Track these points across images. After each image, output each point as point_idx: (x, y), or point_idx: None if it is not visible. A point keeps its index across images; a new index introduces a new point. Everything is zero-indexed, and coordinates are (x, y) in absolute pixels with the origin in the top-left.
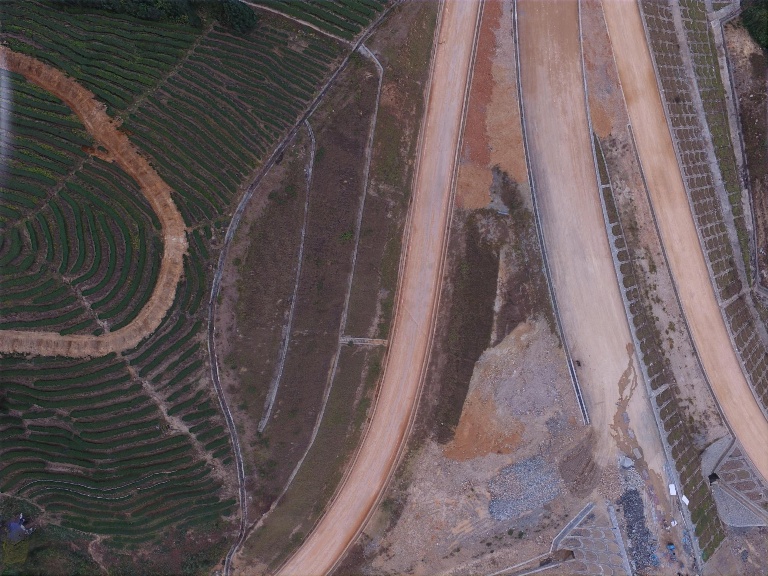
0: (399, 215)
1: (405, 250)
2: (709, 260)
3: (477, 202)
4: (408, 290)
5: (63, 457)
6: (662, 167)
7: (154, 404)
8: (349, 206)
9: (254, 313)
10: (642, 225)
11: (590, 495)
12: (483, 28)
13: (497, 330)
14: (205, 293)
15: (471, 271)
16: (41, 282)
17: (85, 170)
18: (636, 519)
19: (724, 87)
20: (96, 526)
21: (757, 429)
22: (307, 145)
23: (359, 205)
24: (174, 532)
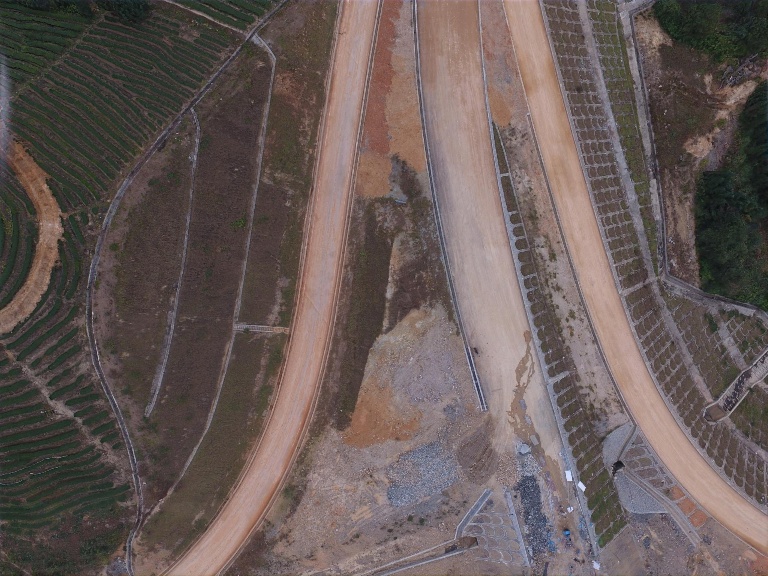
0: (300, 204)
1: (306, 239)
2: (609, 248)
3: (376, 191)
4: (310, 278)
5: None
6: (562, 156)
7: (36, 388)
8: (241, 194)
9: (135, 298)
10: (542, 214)
11: (488, 481)
12: (383, 18)
13: (389, 317)
14: (82, 278)
15: (368, 259)
16: None
17: None
18: (533, 505)
19: (633, 78)
20: None
21: (658, 416)
22: (192, 133)
23: (252, 193)
24: (71, 517)
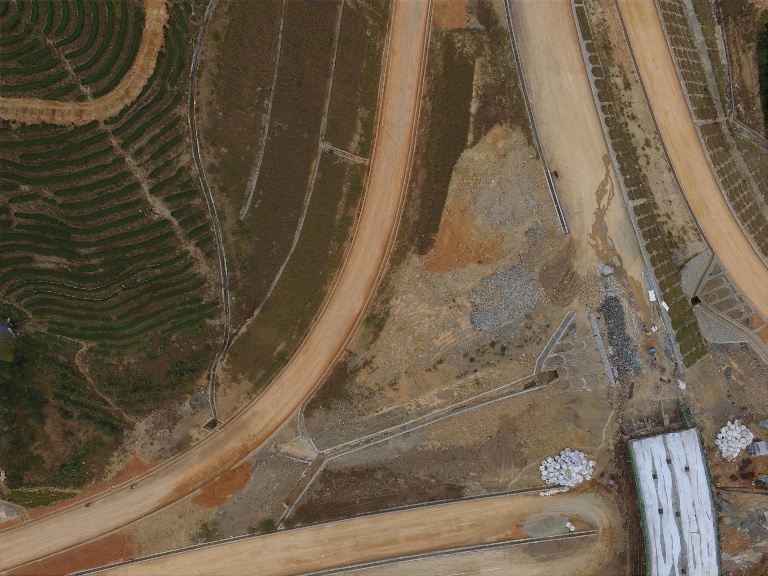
0: (378, 37)
1: (384, 71)
2: (682, 78)
3: (454, 22)
4: (388, 111)
5: (49, 249)
6: None
7: (137, 182)
8: (327, 12)
9: (234, 94)
10: (616, 44)
11: (571, 304)
12: None
13: (474, 131)
14: (185, 66)
15: (448, 84)
16: (26, 44)
17: None
18: (617, 325)
19: None
20: (82, 332)
21: (736, 245)
22: None
23: (337, 14)
24: (159, 337)
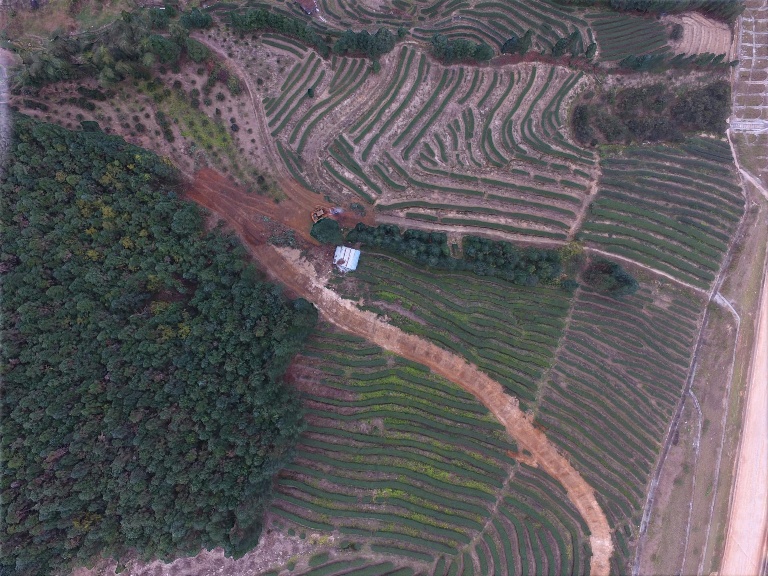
0: (731, 447)
1: (735, 482)
2: None
3: None
4: (737, 521)
5: None
6: None
7: None
8: (711, 460)
9: None
10: None
11: None
12: None
13: None
14: None
15: None
16: None
17: (515, 478)
18: None
19: None
20: None
21: None
22: (695, 418)
23: (717, 456)
24: None
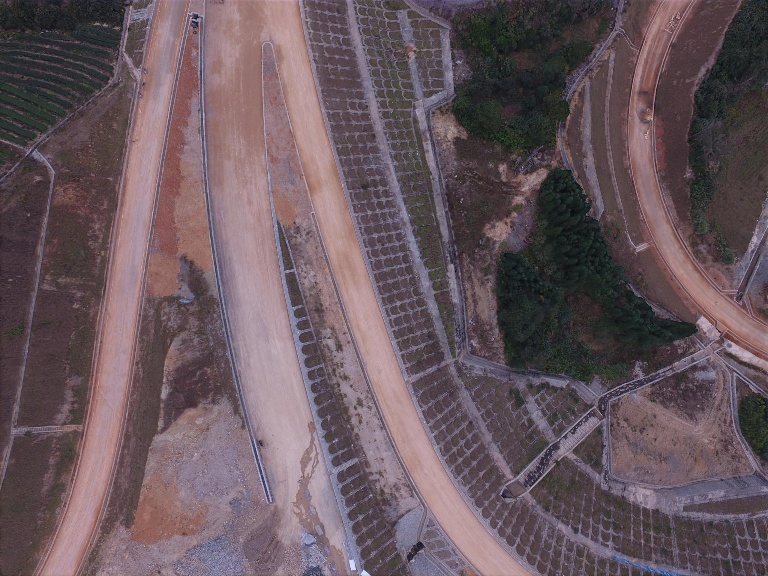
0: (92, 304)
1: (99, 337)
2: (394, 337)
3: (165, 290)
4: (103, 375)
5: None
6: (346, 251)
7: None
8: (17, 302)
9: None
10: (327, 306)
11: (275, 573)
12: (172, 127)
13: (164, 417)
14: None
15: (153, 358)
16: None
17: None
18: None
19: (430, 169)
20: None
21: (449, 499)
22: None
23: (31, 300)
24: None
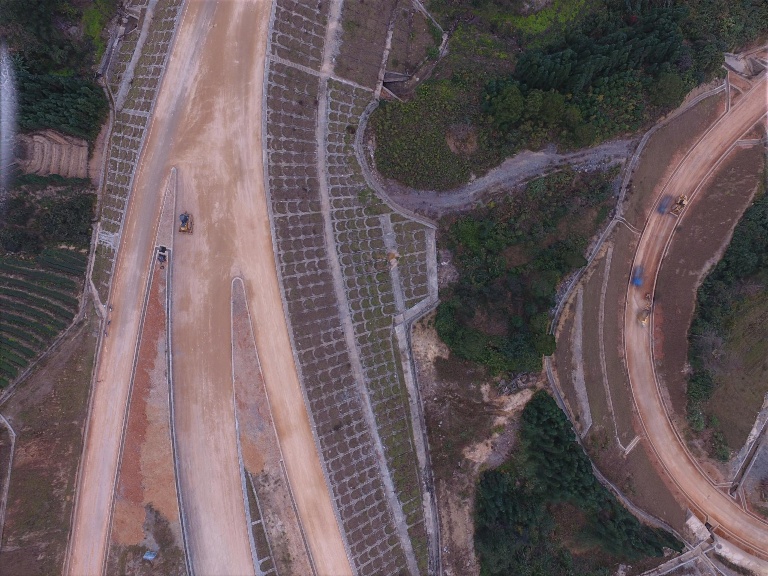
0: (57, 550)
1: None
2: None
3: (131, 539)
4: None
5: None
6: (315, 500)
7: None
8: None
9: None
10: (295, 557)
11: None
12: (138, 369)
13: None
14: None
15: None
16: None
17: None
18: None
19: (408, 391)
20: None
21: None
22: None
23: None
24: None
